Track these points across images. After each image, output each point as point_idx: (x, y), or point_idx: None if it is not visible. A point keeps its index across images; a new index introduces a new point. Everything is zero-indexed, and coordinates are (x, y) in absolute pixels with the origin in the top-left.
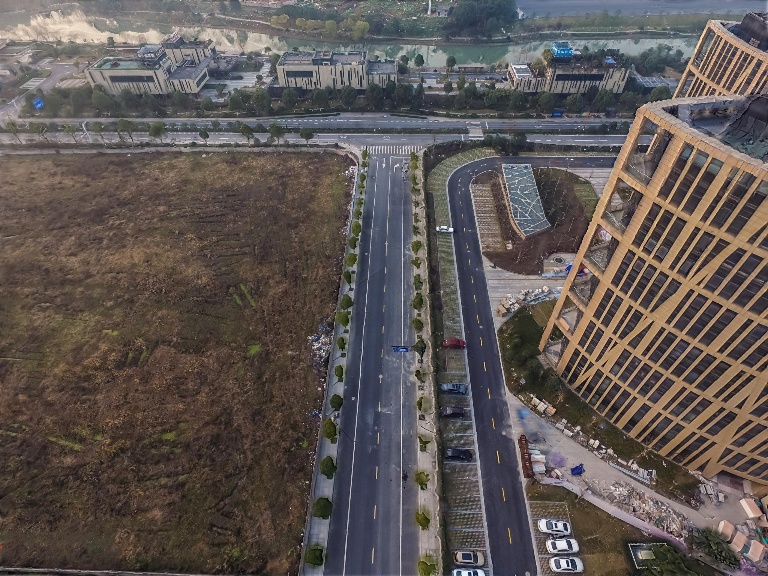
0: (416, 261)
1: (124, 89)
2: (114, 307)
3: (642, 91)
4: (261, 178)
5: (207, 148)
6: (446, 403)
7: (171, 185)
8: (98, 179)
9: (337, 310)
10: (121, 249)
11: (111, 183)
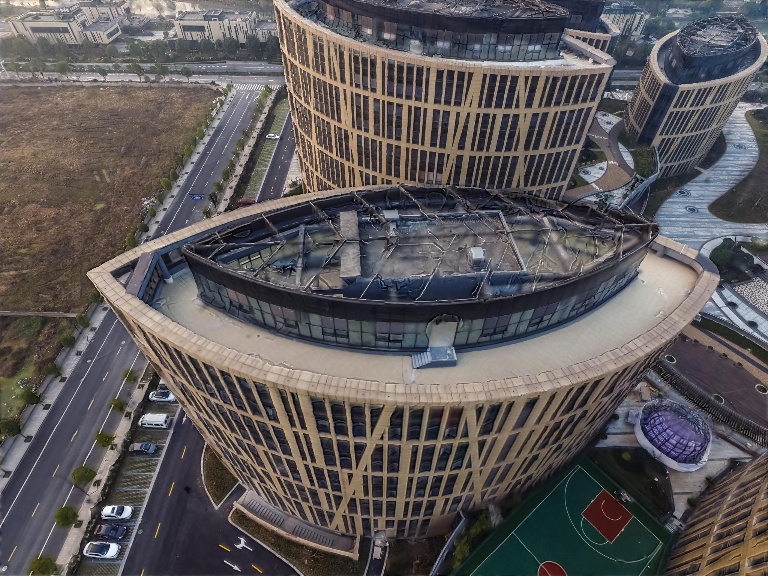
0: (235, 151)
1: (40, 36)
2: (1, 182)
3: None
4: (143, 104)
5: (104, 83)
6: None
7: (68, 108)
8: (9, 103)
9: None
10: (15, 148)
11: (19, 106)
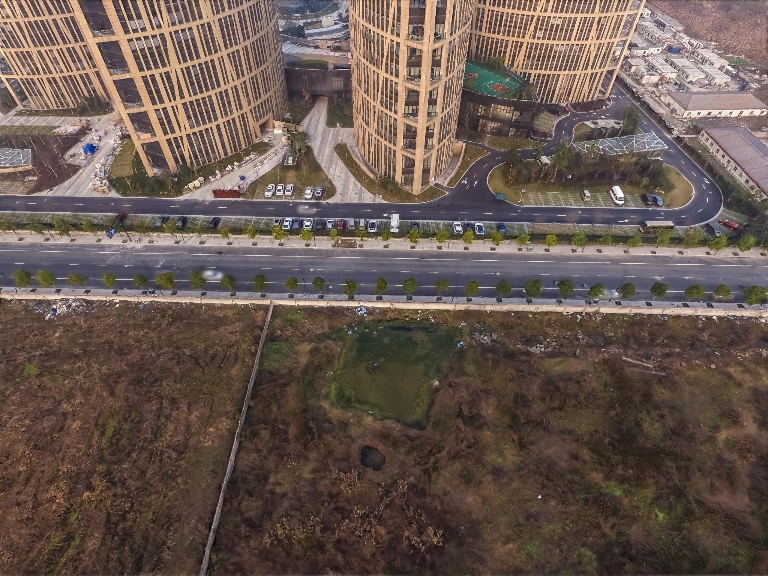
0: (6, 224)
1: None
2: None
3: None
4: None
5: None
6: None
7: None
8: None
9: (24, 295)
10: None
11: None
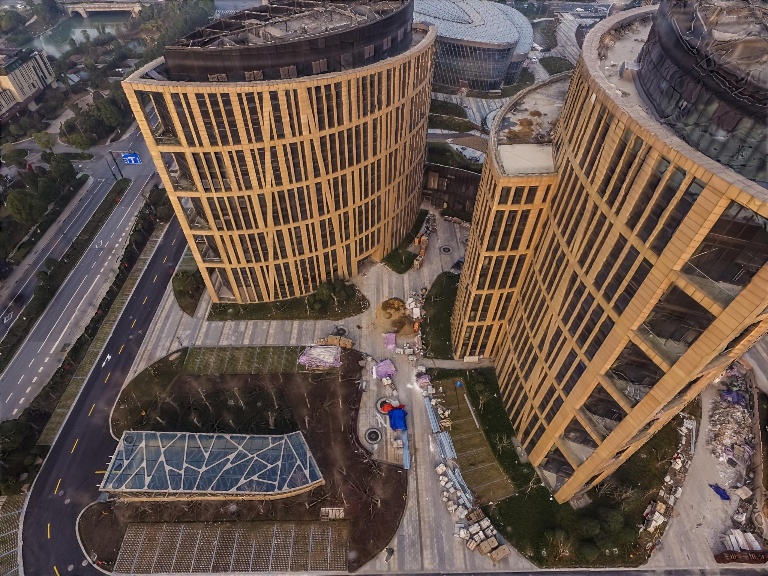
0: None
1: None
2: None
3: None
4: None
5: None
6: None
7: None
8: None
9: None
10: None
11: None
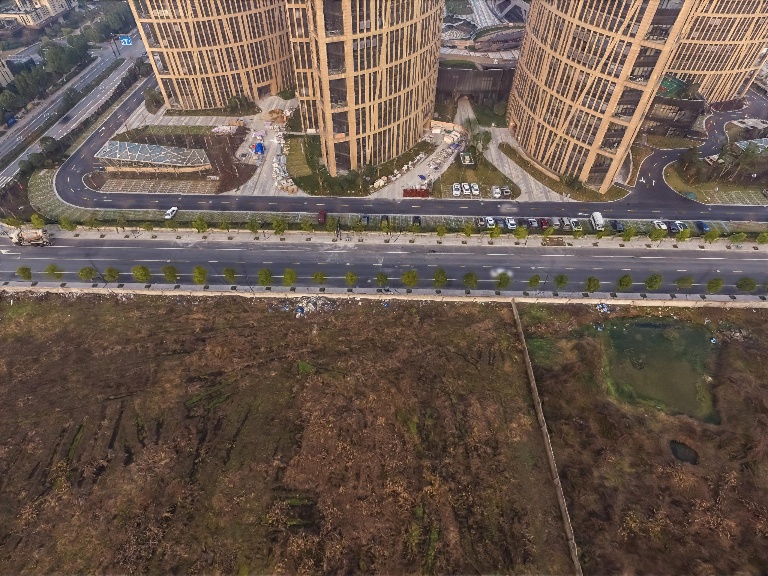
0: (224, 223)
1: None
2: None
3: (26, 68)
4: None
5: None
6: (376, 226)
7: None
8: None
9: (266, 293)
10: None
11: None
